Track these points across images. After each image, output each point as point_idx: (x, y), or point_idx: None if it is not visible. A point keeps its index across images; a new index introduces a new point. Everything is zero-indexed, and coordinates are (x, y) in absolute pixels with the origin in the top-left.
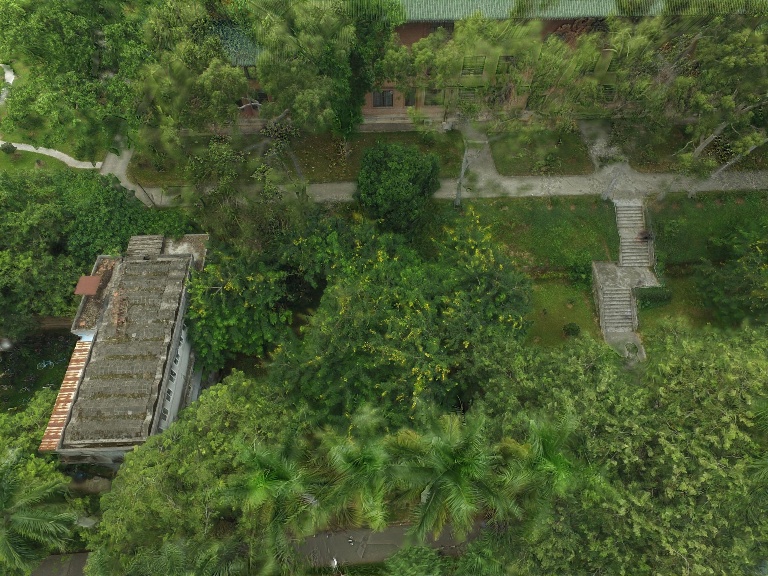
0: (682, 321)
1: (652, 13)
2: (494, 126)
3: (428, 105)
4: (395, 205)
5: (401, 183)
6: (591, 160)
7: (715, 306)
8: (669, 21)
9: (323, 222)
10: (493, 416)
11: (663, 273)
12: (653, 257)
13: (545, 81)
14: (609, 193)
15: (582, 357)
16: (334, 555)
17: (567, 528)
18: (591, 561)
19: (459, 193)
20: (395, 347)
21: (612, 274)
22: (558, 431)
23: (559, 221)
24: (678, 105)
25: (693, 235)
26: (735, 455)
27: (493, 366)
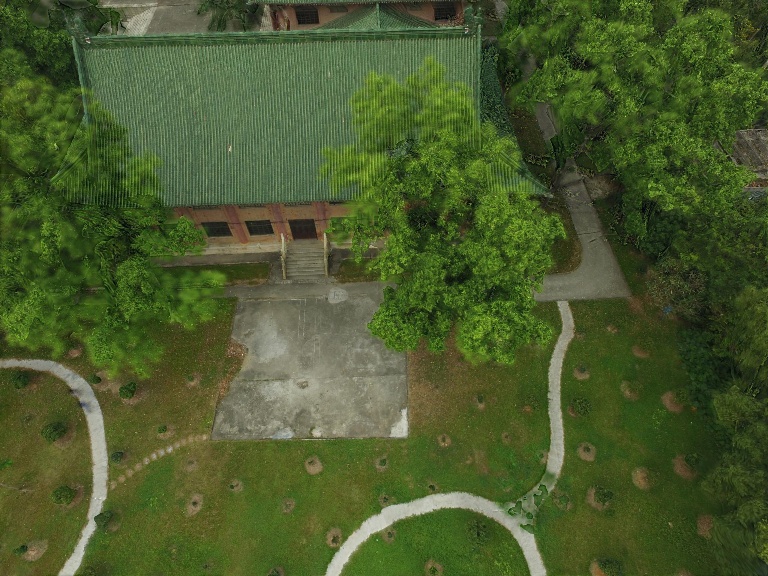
0: None
1: None
2: None
3: None
4: None
5: None
6: None
7: None
8: None
9: None
10: (751, 3)
11: None
12: None
13: None
14: None
15: None
16: None
17: None
18: None
19: None
20: None
21: None
22: None
23: None
24: None
25: None
26: None
27: None
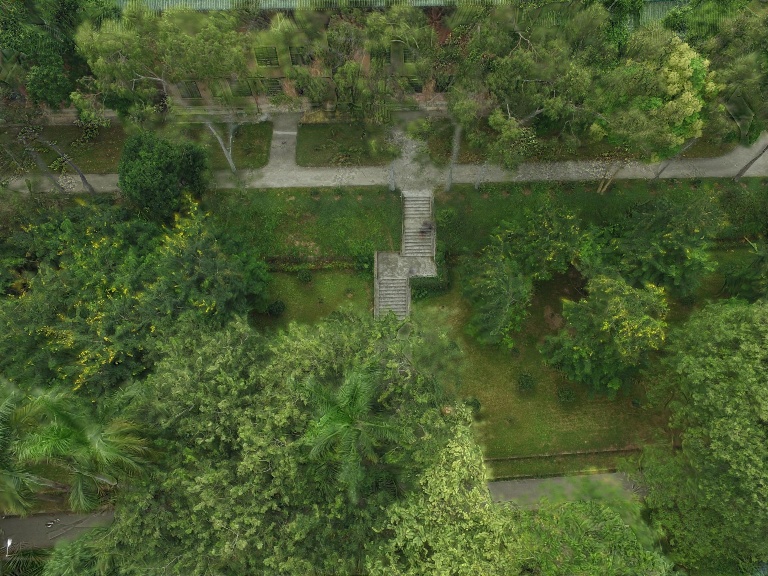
0: (353, 306)
1: (416, 3)
2: (303, 117)
3: (237, 96)
4: (150, 194)
5: (146, 171)
6: (393, 151)
7: (469, 295)
8: (438, 12)
9: (53, 209)
10: None
11: (443, 263)
12: (434, 247)
13: (346, 72)
14: (401, 184)
15: (221, 340)
16: (11, 536)
17: (157, 506)
18: (182, 539)
19: (239, 183)
20: (84, 331)
21: (393, 264)
22: (105, 408)
23: (343, 211)
24: (490, 97)
25: (478, 225)
26: (298, 433)
27: (162, 350)
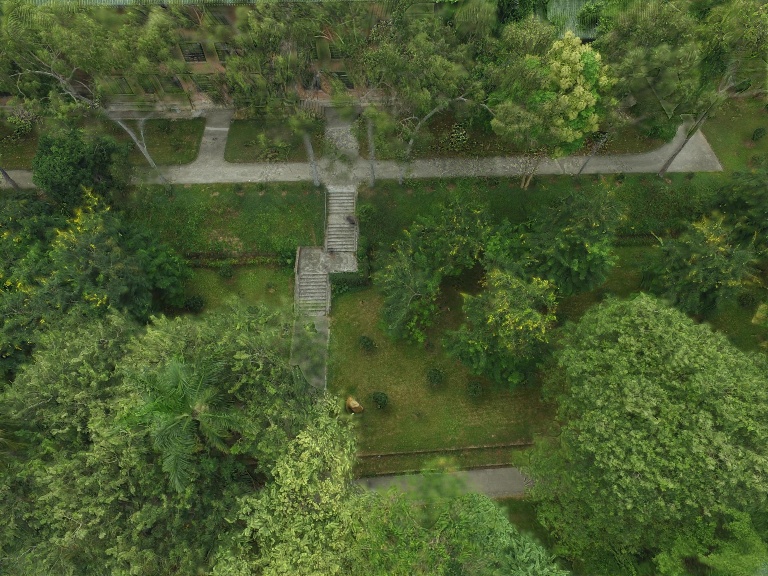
0: (236, 299)
1: None
2: (235, 113)
3: (169, 92)
4: (63, 189)
5: (56, 166)
6: (322, 147)
7: None
8: (355, 7)
9: None
10: None
11: (365, 258)
12: None
13: (275, 68)
14: (326, 179)
15: (94, 332)
16: None
17: (14, 497)
18: (39, 529)
19: (161, 178)
20: None
21: (315, 259)
22: None
23: (267, 207)
24: (423, 93)
25: (402, 221)
26: (144, 424)
27: None
